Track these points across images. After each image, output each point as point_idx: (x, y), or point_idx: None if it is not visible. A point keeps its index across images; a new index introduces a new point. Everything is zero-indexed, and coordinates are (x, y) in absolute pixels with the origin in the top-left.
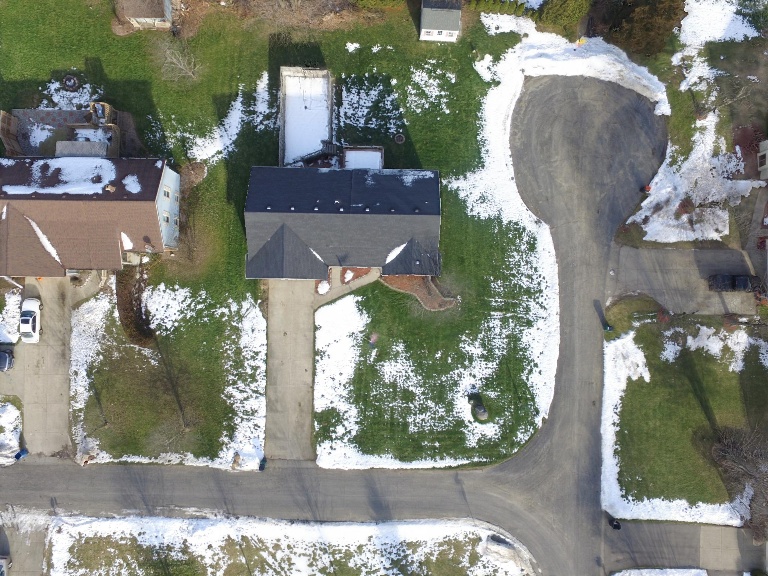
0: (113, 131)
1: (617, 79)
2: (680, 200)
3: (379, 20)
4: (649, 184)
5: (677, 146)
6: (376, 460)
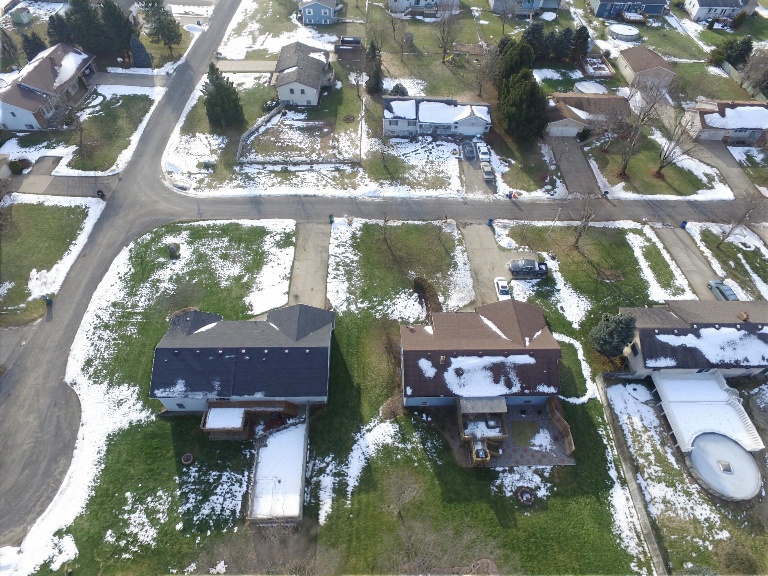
0: None
1: None
2: None
3: None
4: None
5: None
6: (255, 223)
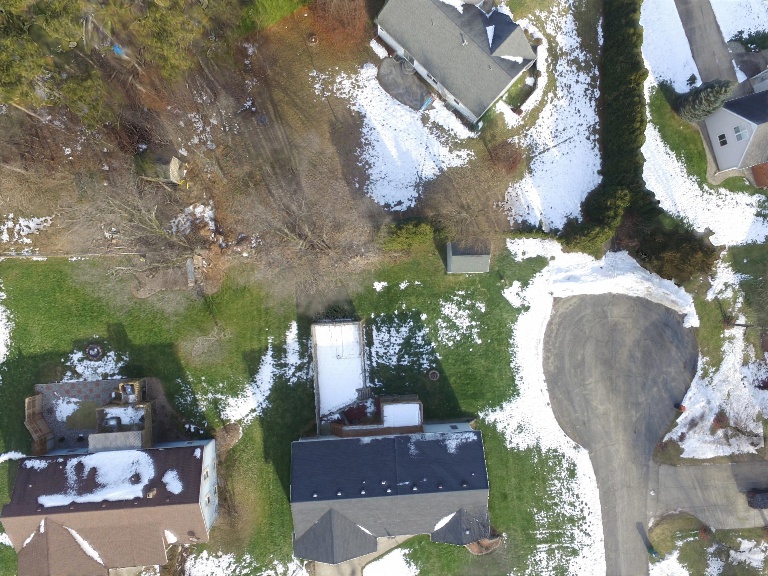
0: (145, 412)
1: (645, 294)
2: (714, 414)
3: (405, 257)
4: (683, 399)
5: (708, 357)
6: None
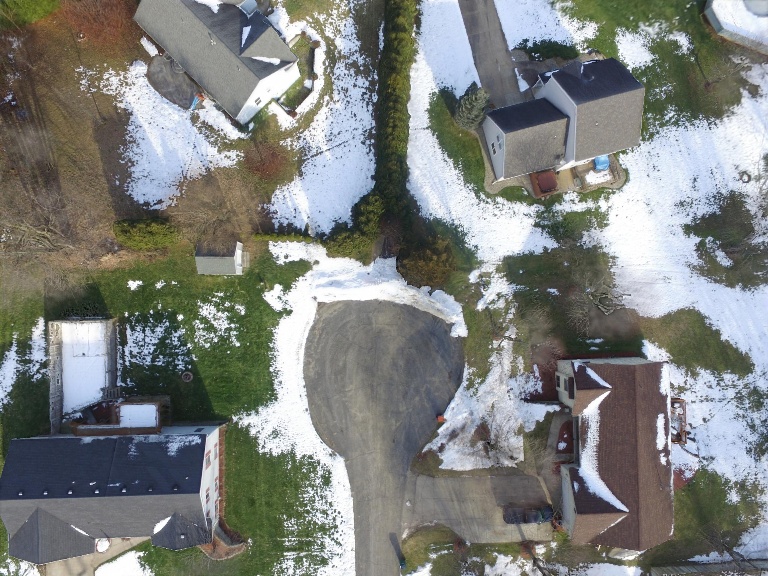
0: None
1: (412, 302)
2: (476, 426)
3: (161, 256)
4: (446, 409)
5: (474, 368)
6: None
